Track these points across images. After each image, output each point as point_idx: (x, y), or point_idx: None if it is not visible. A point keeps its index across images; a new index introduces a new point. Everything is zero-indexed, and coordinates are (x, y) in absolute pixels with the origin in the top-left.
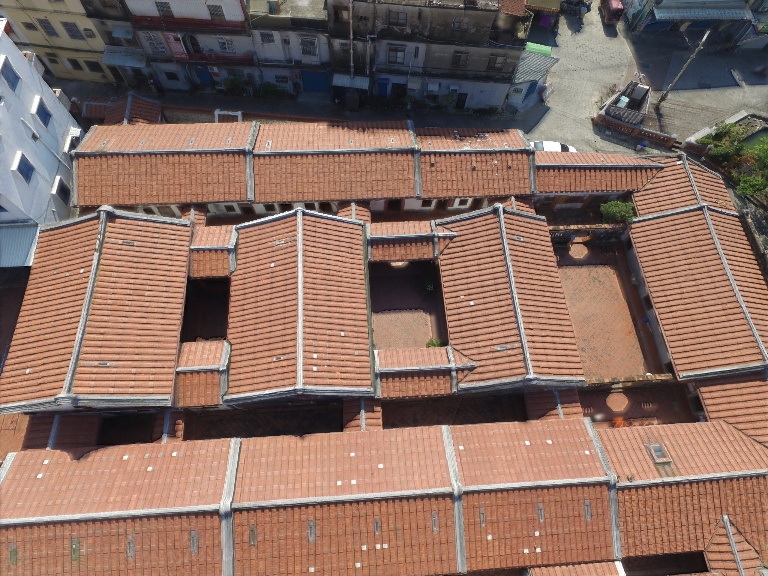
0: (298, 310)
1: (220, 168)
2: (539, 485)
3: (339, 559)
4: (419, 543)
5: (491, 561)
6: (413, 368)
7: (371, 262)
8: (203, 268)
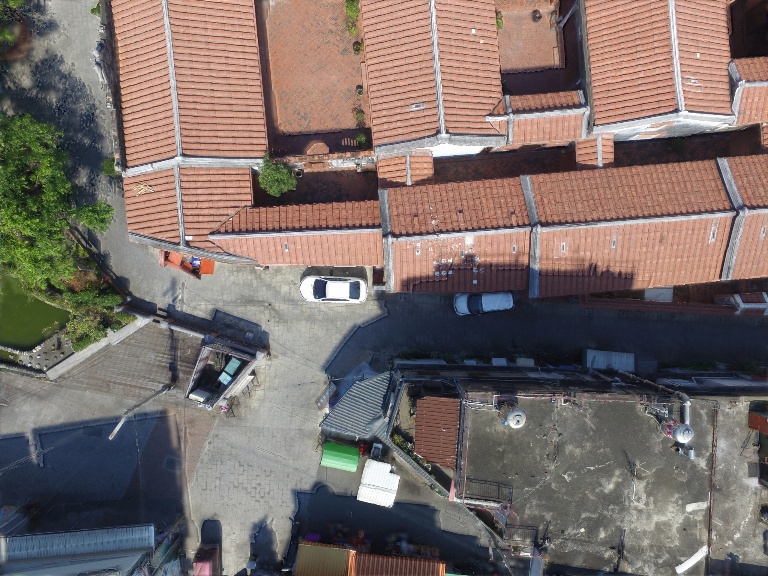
0: None
1: None
2: None
3: None
4: None
5: None
6: None
7: None
8: (763, 65)
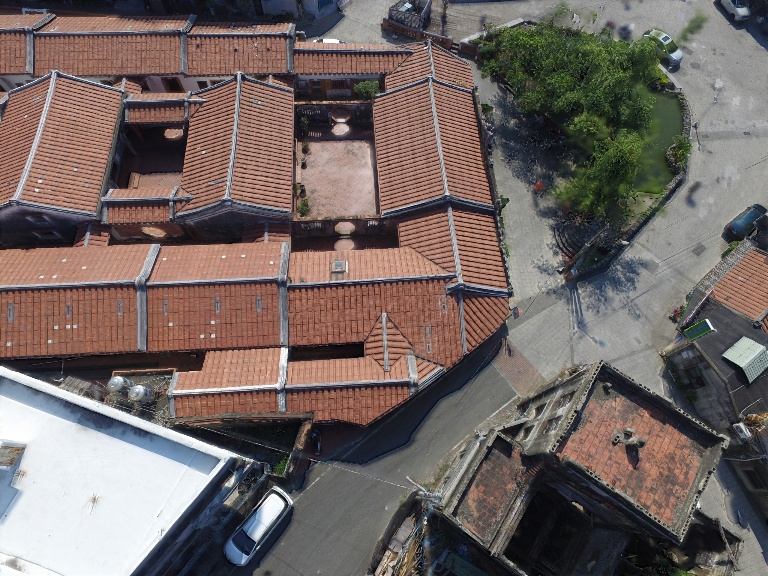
0: (32, 146)
1: (3, 45)
2: (216, 281)
3: (34, 336)
4: (105, 325)
5: (171, 344)
6: (135, 198)
7: (129, 124)
8: None
